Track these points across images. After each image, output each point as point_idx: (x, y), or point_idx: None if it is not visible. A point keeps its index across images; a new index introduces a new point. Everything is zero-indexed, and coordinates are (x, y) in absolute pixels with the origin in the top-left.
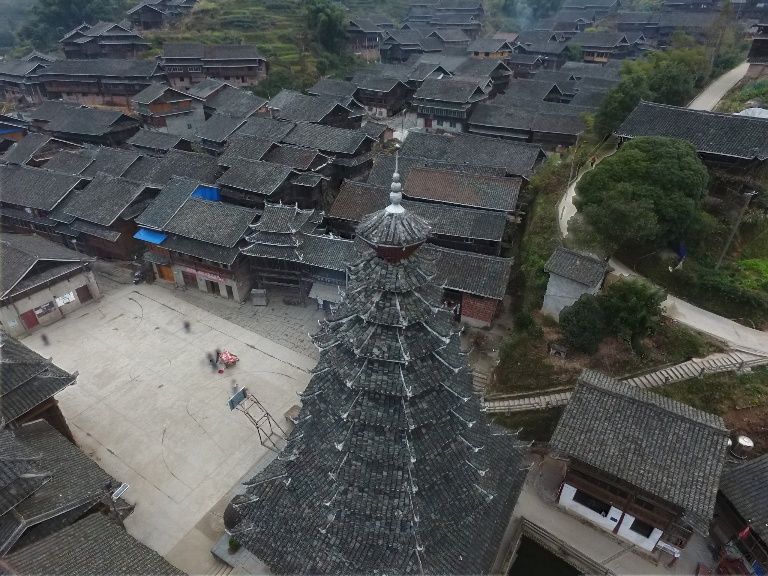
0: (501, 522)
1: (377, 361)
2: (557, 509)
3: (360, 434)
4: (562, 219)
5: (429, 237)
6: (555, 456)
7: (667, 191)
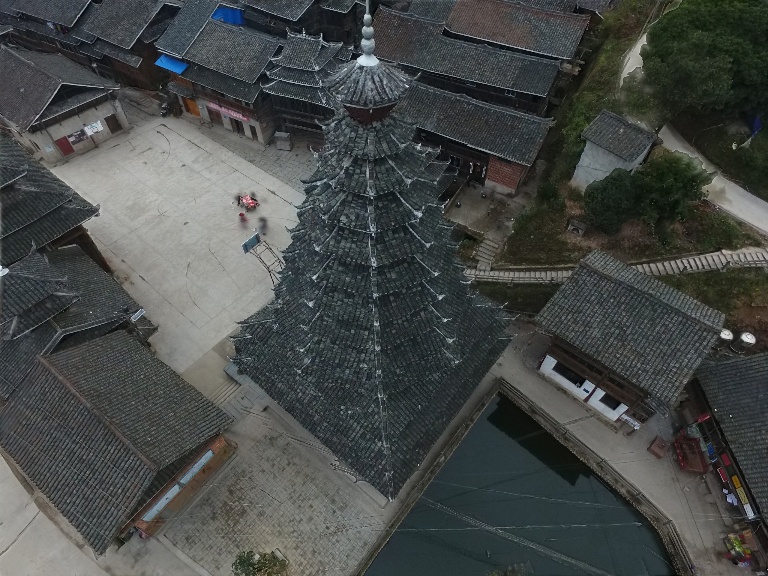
0: (473, 381)
1: (348, 228)
2: (537, 375)
3: (331, 295)
4: (625, 73)
5: (466, 86)
6: (540, 330)
7: (759, 46)
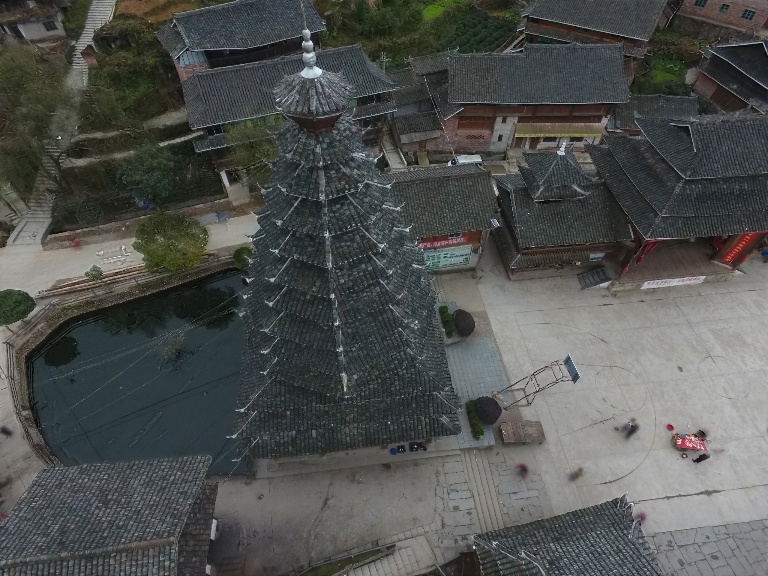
0: None
1: None
2: None
3: None
4: None
5: None
6: None
7: None
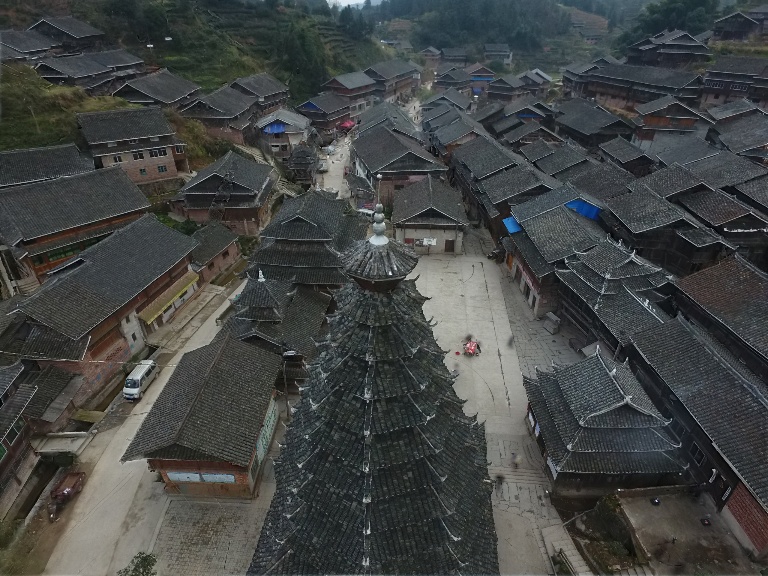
0: None
1: None
2: None
3: None
4: None
5: None
6: None
7: None
